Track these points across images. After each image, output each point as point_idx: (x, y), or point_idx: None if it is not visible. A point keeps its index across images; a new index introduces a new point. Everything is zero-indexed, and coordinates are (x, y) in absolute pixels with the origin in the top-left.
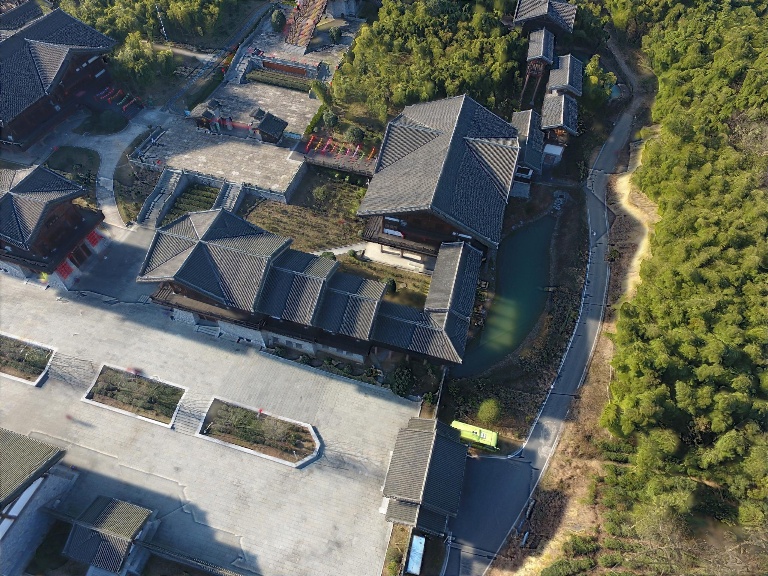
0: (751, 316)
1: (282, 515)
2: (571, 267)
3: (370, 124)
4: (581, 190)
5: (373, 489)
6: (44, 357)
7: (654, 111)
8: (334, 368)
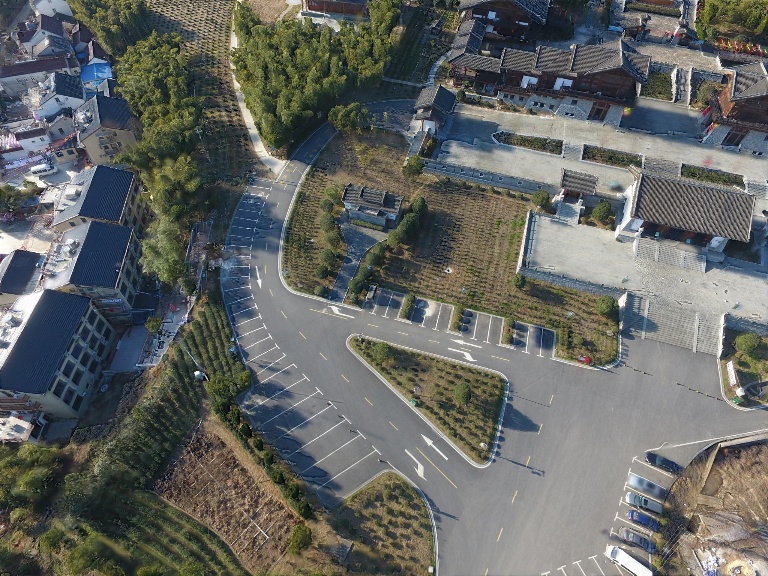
0: None
1: None
2: None
3: None
4: None
5: None
6: (638, 159)
7: None
8: None
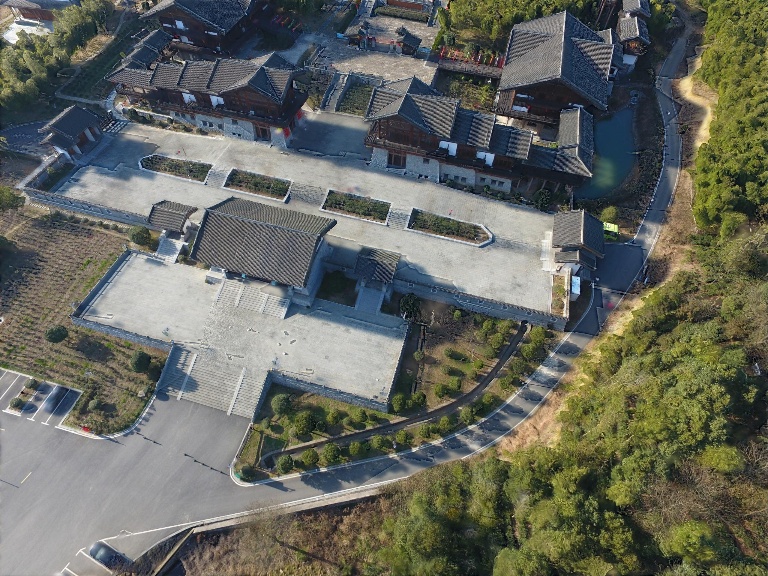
0: None
1: (477, 271)
2: (653, 136)
3: (480, 44)
4: (652, 89)
5: (535, 259)
6: (285, 186)
7: (707, 30)
8: (490, 195)
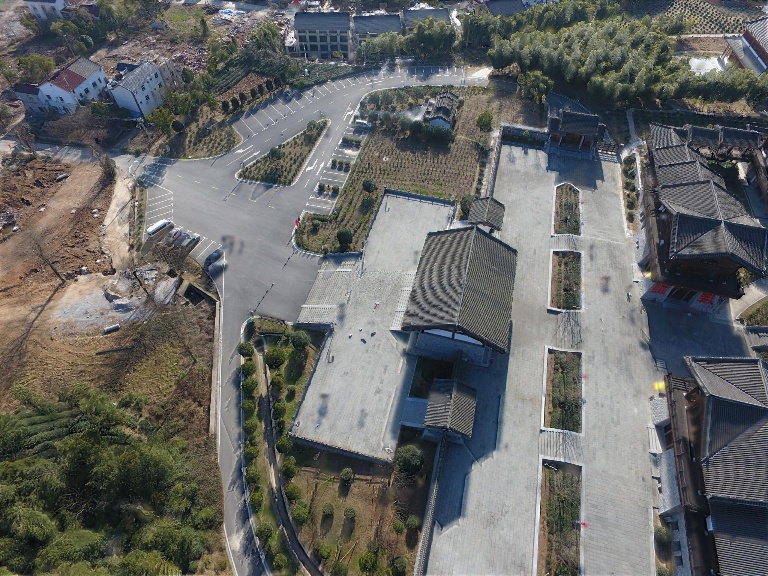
0: None
1: (483, 569)
2: None
3: None
4: None
5: None
6: (573, 305)
7: None
8: None
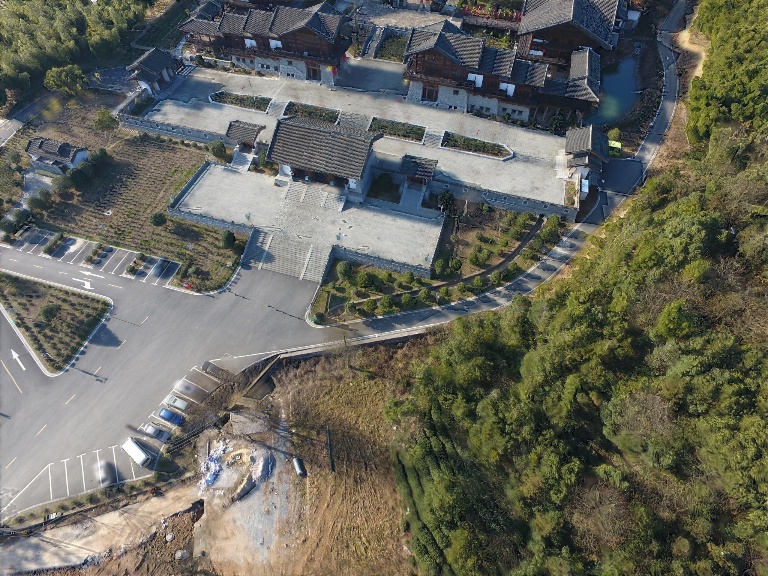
0: None
1: (501, 178)
2: (653, 77)
3: None
4: (654, 40)
5: (550, 170)
6: (335, 114)
7: None
8: (510, 123)
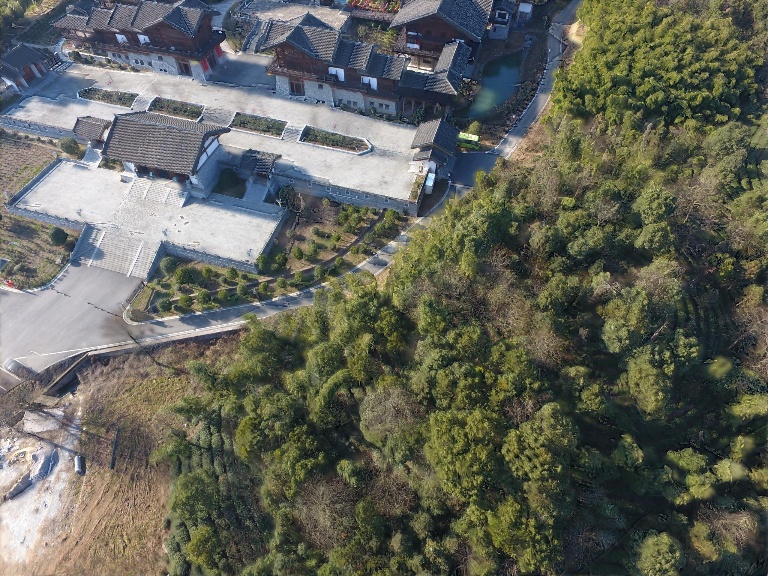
0: (636, 64)
1: (352, 172)
2: (533, 70)
3: None
4: (544, 33)
5: (404, 164)
6: (199, 110)
7: None
8: (377, 117)
